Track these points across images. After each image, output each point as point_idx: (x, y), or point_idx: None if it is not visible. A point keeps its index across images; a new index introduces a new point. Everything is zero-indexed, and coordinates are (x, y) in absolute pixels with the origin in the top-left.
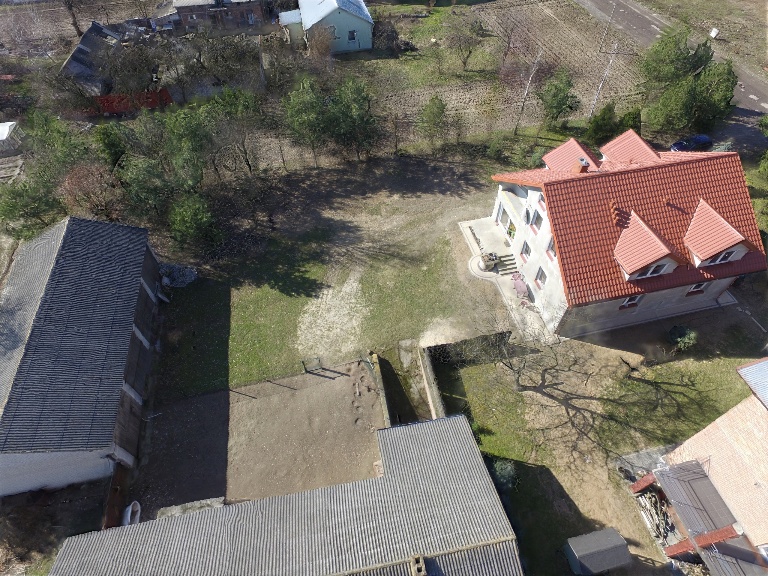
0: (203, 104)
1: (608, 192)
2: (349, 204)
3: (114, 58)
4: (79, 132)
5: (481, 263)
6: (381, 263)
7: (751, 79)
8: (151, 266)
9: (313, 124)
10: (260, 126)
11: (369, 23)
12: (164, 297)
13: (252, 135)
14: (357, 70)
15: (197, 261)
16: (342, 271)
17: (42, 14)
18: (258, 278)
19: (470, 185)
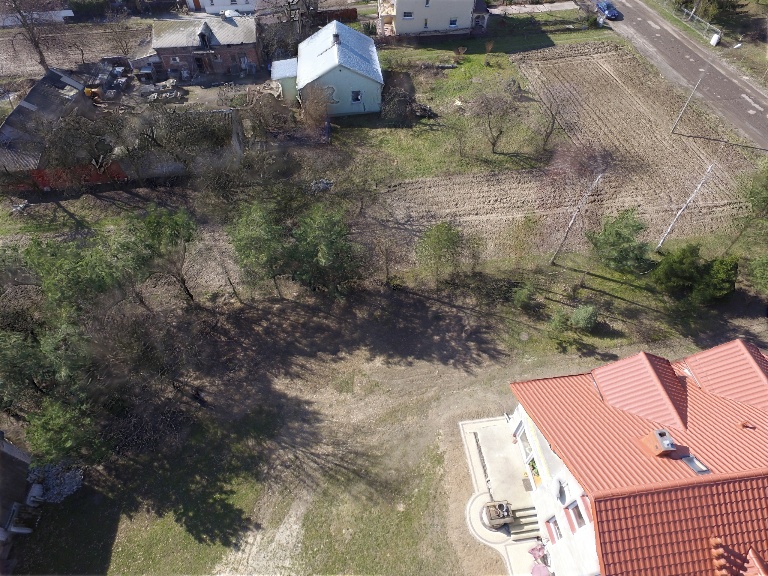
0: (163, 182)
1: (708, 515)
2: (312, 368)
3: (50, 128)
4: (9, 213)
5: (485, 518)
6: (339, 488)
7: None
8: (8, 481)
9: (268, 259)
10: (224, 221)
11: (377, 83)
12: (22, 527)
13: (211, 235)
14: (358, 142)
15: (90, 452)
16: (282, 498)
17: (21, 42)
18: (162, 498)
19: (483, 351)
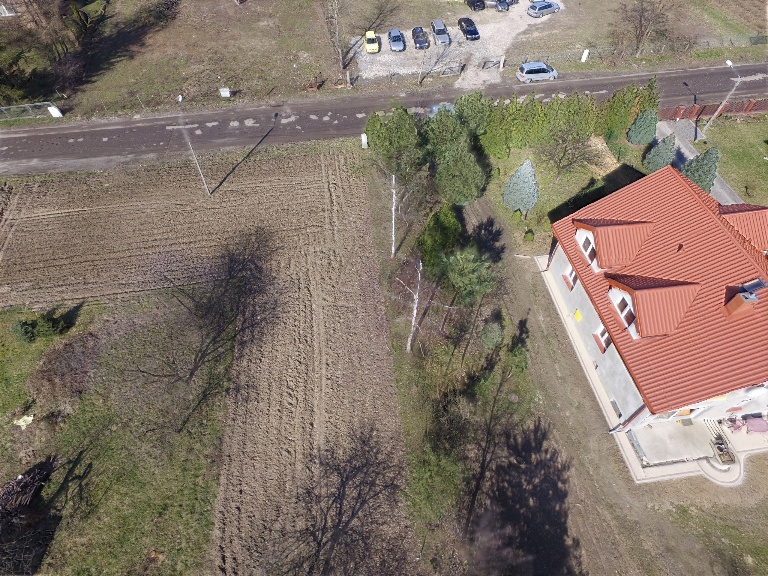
0: None
1: None
2: None
3: None
4: None
5: None
6: None
7: (324, 105)
8: None
9: None
10: None
11: None
12: None
13: None
14: None
15: None
16: None
17: None
18: None
19: (540, 446)
